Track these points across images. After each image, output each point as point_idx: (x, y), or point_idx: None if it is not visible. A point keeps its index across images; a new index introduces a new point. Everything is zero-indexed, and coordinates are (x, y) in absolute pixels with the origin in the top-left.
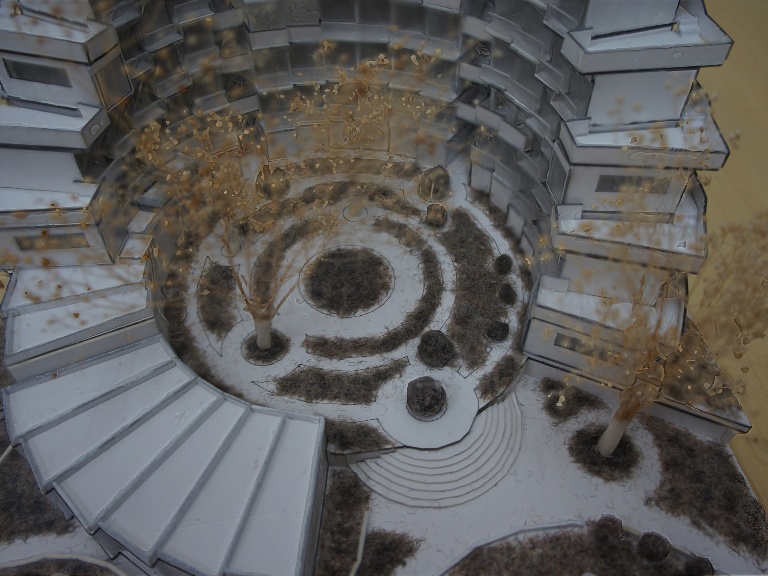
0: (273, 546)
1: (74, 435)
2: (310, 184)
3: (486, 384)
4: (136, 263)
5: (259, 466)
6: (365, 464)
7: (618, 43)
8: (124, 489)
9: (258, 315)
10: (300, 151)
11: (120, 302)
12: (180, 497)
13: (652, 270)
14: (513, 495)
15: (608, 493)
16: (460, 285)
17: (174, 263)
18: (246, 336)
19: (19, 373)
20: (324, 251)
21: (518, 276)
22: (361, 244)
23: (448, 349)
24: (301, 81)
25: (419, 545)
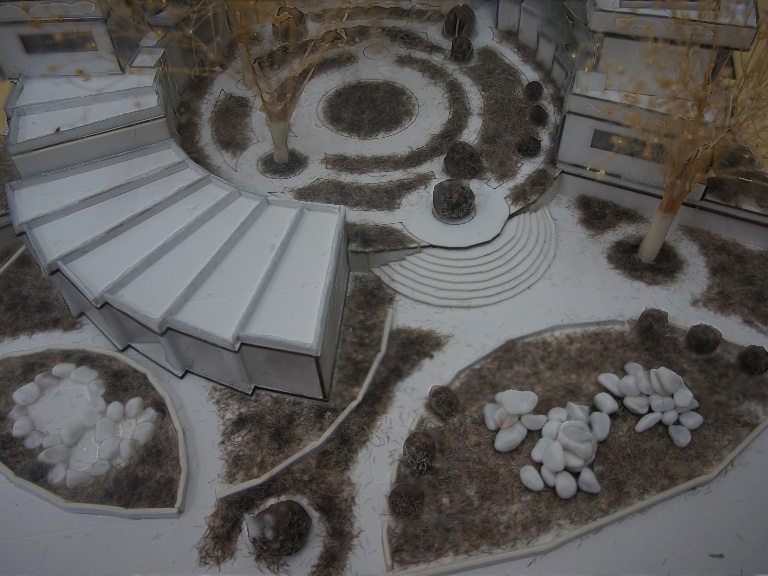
0: (291, 315)
1: (81, 225)
2: (329, 29)
3: (517, 192)
4: (147, 73)
5: (276, 249)
6: (389, 267)
7: None
8: (132, 267)
9: (274, 114)
10: (318, 2)
11: (130, 104)
12: (192, 275)
13: (698, 50)
14: (548, 296)
15: (651, 295)
16: (488, 109)
17: (187, 94)
18: (262, 154)
19: (24, 167)
20: (344, 84)
21: (549, 102)
22: (383, 78)
23: (476, 158)
24: None
25: (447, 340)
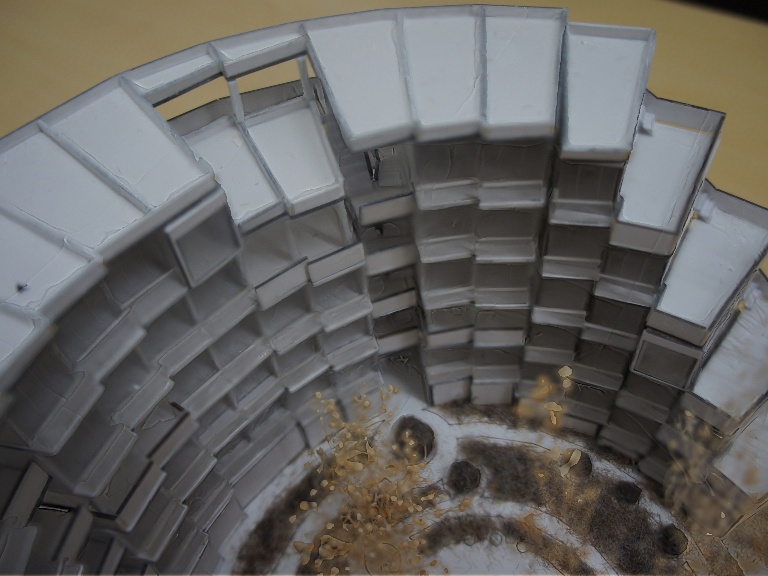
0: None
1: None
2: None
3: None
4: None
5: None
6: None
7: (627, 187)
8: None
9: None
10: (217, 551)
11: None
12: None
13: None
14: None
15: None
16: (582, 529)
17: None
18: None
19: None
20: None
21: (599, 460)
22: None
23: None
24: (188, 489)
25: None
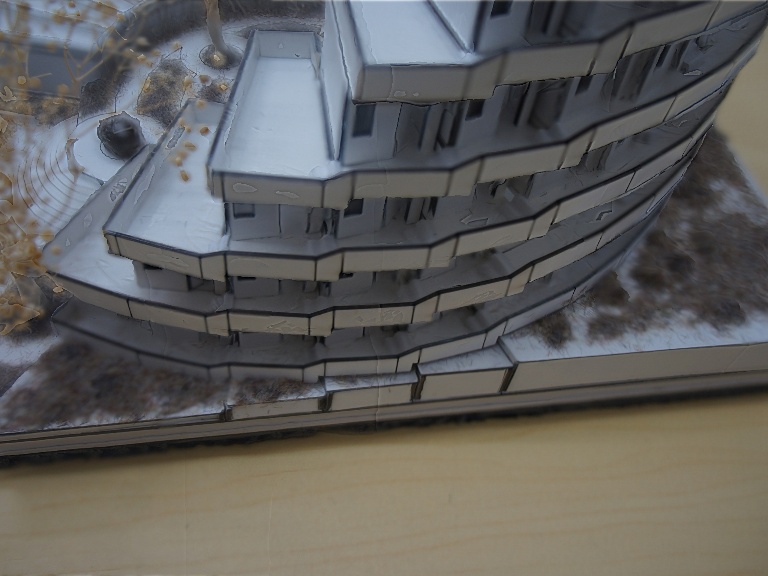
0: None
1: None
2: None
3: None
4: None
5: None
6: None
7: (417, 8)
8: None
9: None
10: None
11: None
12: None
13: None
14: None
15: None
16: None
17: None
18: (237, 46)
19: None
20: None
21: None
22: None
23: None
24: None
25: None
